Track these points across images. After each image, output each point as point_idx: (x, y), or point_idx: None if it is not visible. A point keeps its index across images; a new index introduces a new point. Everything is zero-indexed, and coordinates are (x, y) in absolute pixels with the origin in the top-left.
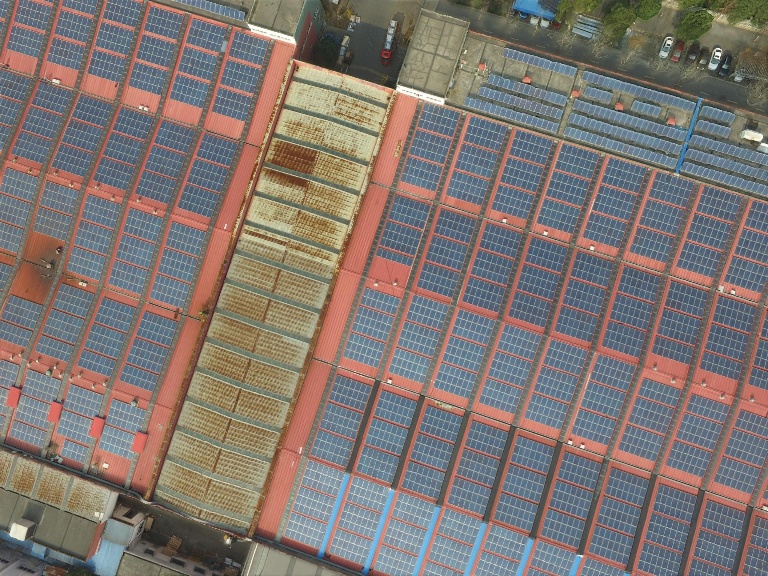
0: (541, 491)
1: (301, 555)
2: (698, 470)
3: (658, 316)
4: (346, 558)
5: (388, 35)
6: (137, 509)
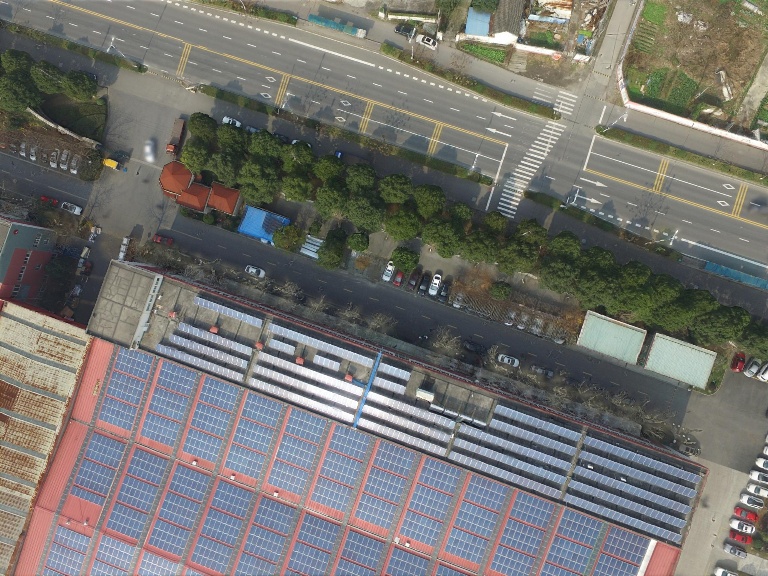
0: None
1: None
2: None
3: (334, 566)
4: None
5: (120, 252)
6: None
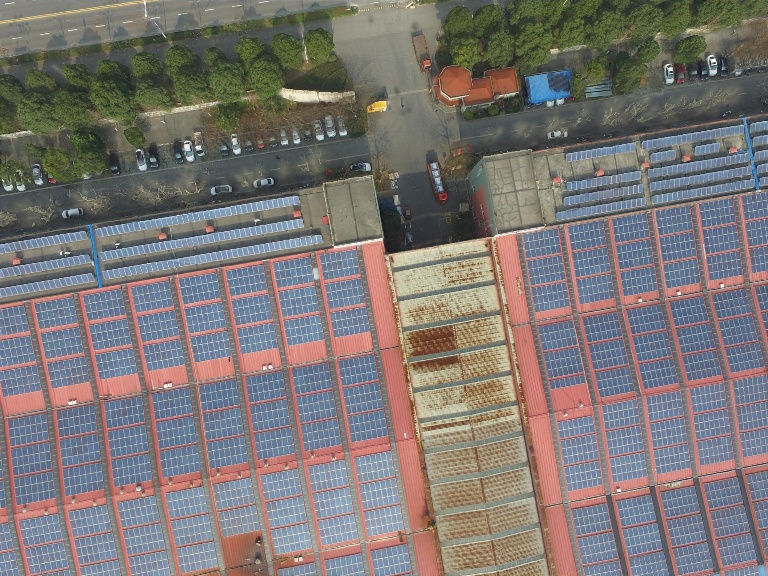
0: None
1: None
2: None
3: None
4: None
5: (435, 178)
6: None
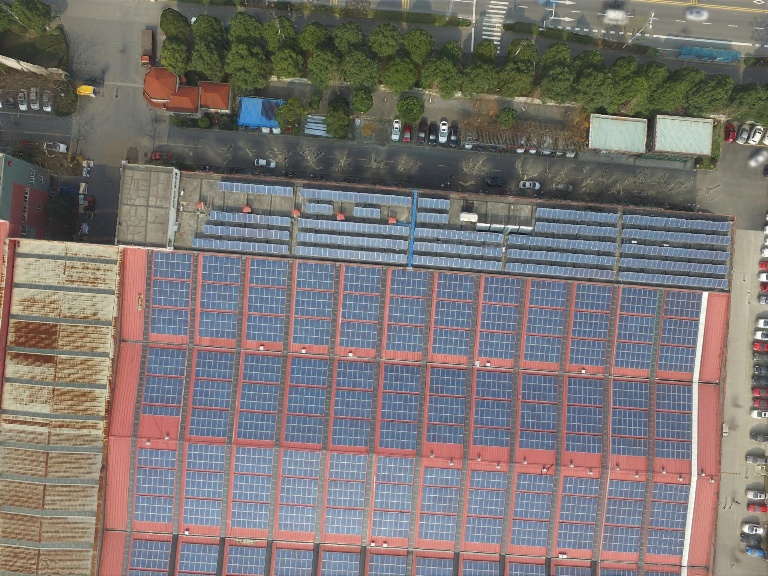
0: None
1: None
2: (494, 538)
3: (425, 404)
4: None
5: None
6: None
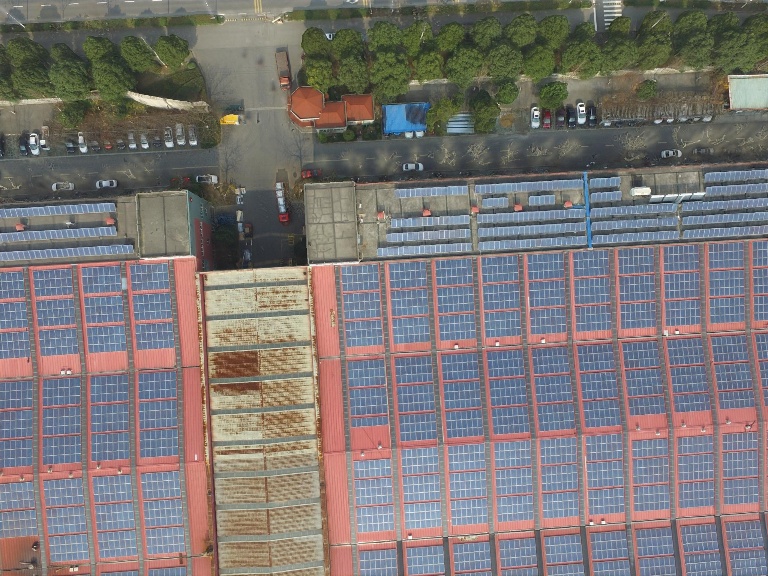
0: None
1: None
2: (707, 501)
3: (623, 380)
4: None
5: (279, 199)
6: None
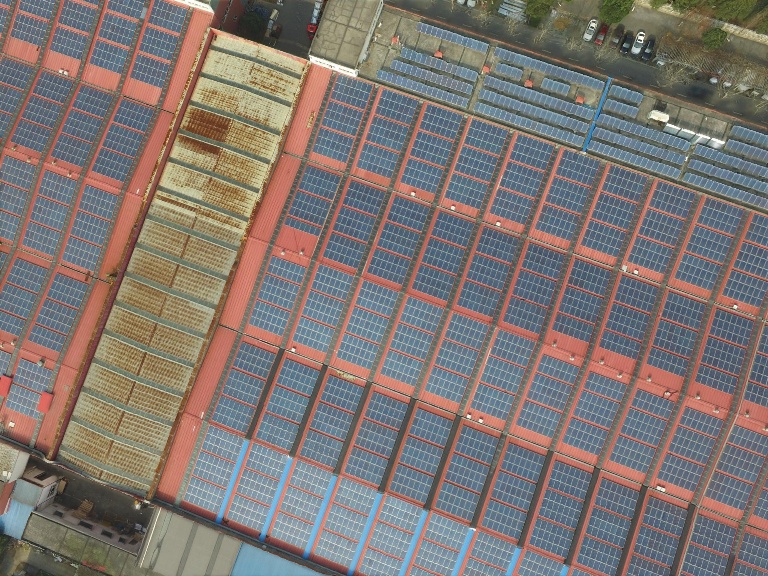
0: (438, 464)
1: (199, 519)
2: (594, 448)
3: (560, 293)
4: (243, 524)
5: (315, 9)
6: (51, 472)
